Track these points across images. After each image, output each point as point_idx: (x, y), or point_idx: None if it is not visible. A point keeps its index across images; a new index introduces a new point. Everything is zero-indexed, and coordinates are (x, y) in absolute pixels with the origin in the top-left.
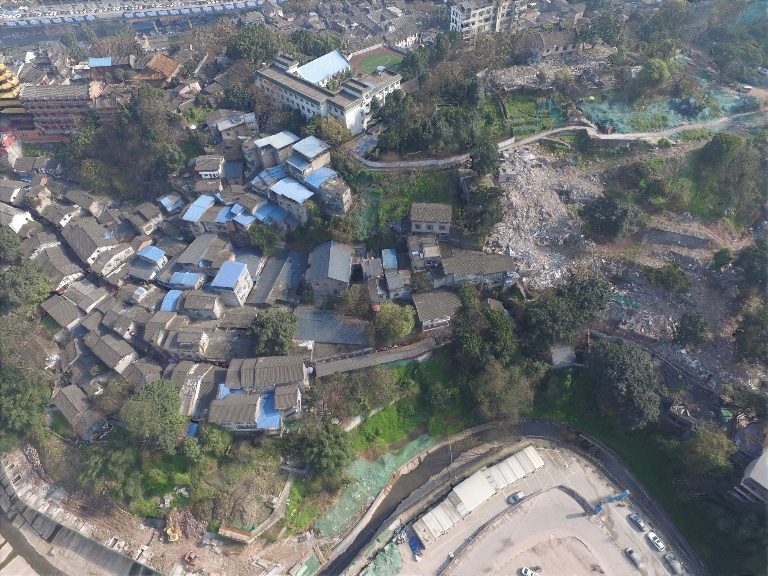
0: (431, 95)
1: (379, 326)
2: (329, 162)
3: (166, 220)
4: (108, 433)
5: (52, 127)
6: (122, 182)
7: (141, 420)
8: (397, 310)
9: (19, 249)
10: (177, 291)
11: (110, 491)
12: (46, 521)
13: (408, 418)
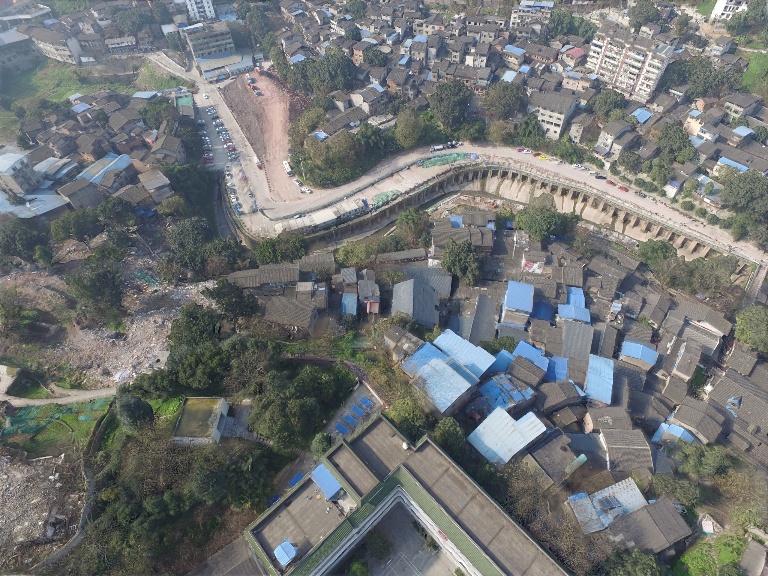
0: None
1: None
2: None
3: (659, 412)
4: None
5: None
6: None
7: None
8: None
9: None
10: None
11: None
12: None
13: None
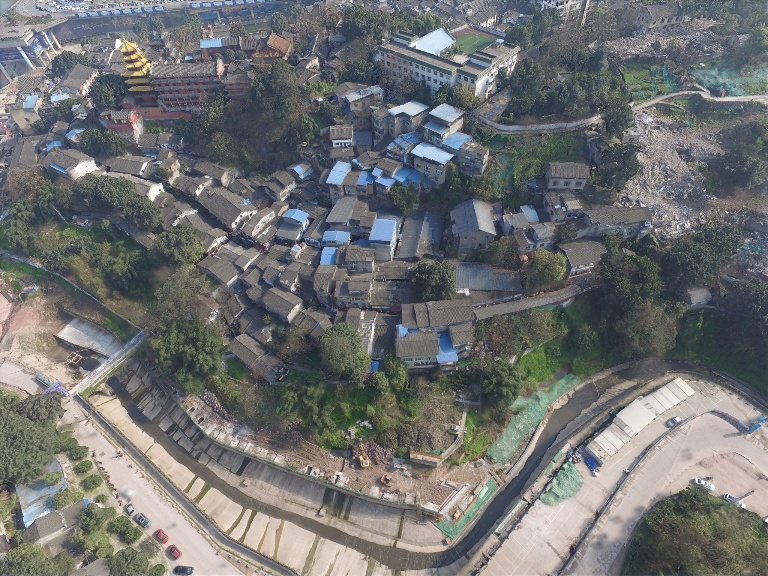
0: (551, 65)
1: (534, 272)
2: (461, 128)
3: (300, 187)
4: (285, 376)
5: (174, 104)
6: (251, 153)
7: (343, 353)
8: (553, 256)
9: (160, 217)
10: (331, 248)
11: (306, 423)
12: (232, 457)
13: (554, 359)
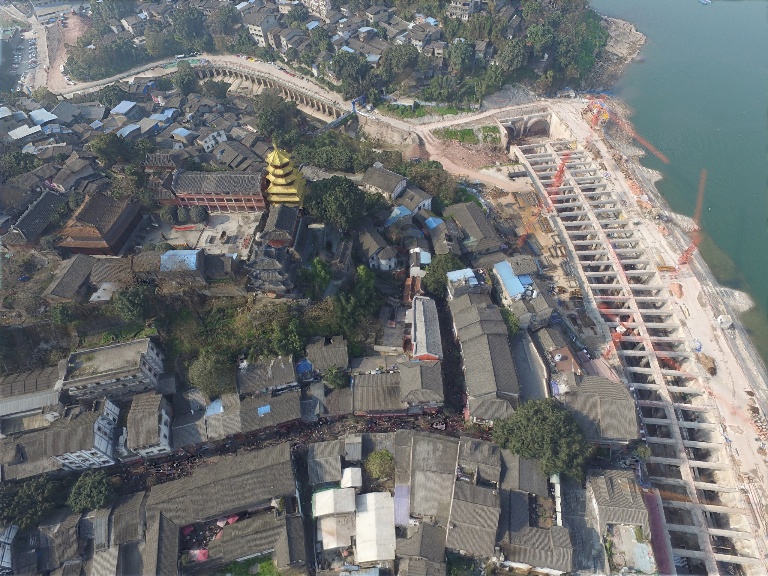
0: None
1: None
2: None
3: None
4: None
5: None
6: None
7: None
8: None
9: None
10: None
11: None
12: None
13: None
